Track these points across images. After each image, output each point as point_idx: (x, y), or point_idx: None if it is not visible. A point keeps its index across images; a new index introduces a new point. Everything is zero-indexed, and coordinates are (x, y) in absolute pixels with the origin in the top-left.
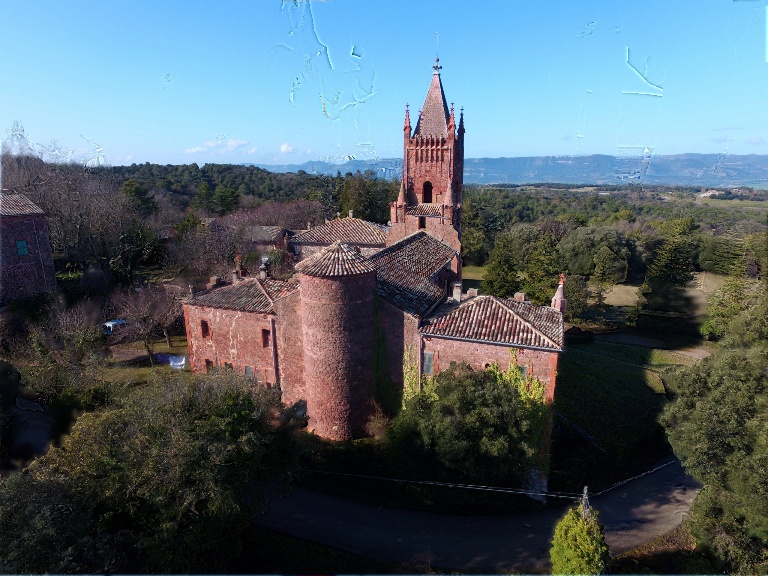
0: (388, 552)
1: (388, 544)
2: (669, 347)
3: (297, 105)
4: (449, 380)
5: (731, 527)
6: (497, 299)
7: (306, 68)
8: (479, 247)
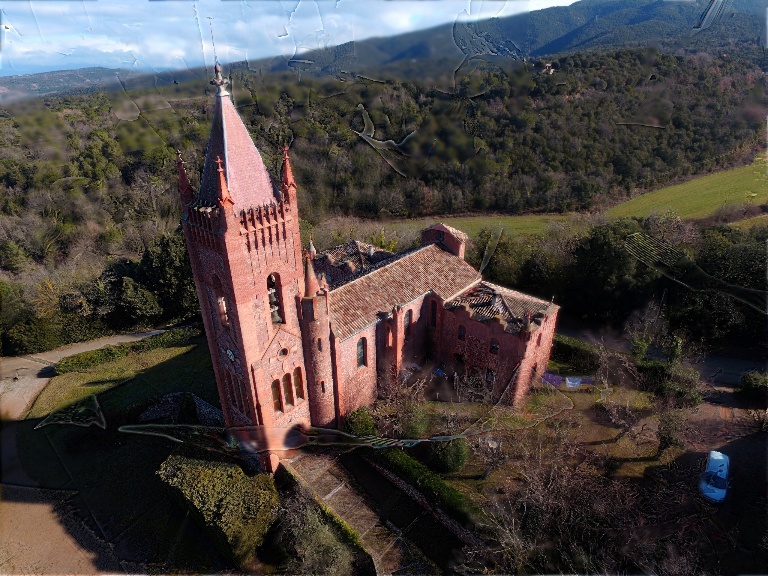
0: None
1: None
2: (4, 424)
3: (467, 158)
4: None
5: None
6: None
7: (455, 102)
8: None
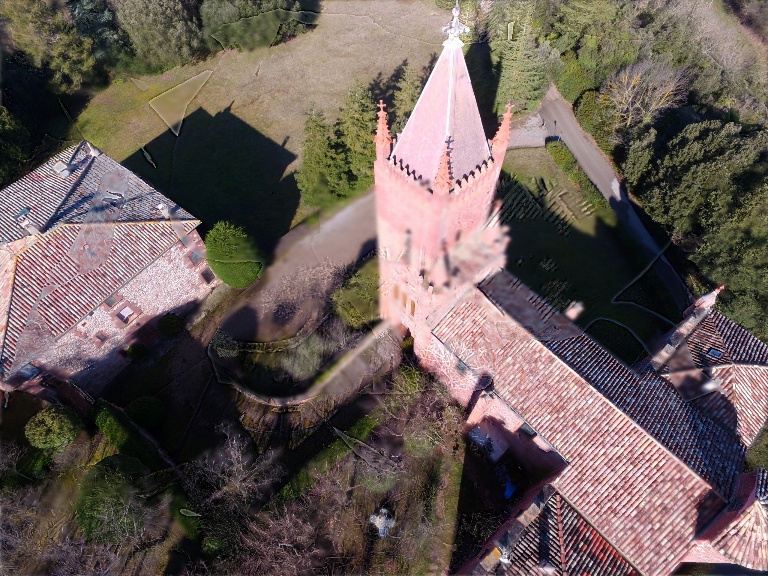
0: None
1: None
2: None
3: None
4: (759, 451)
5: (766, 338)
6: (736, 362)
7: None
8: (94, 62)
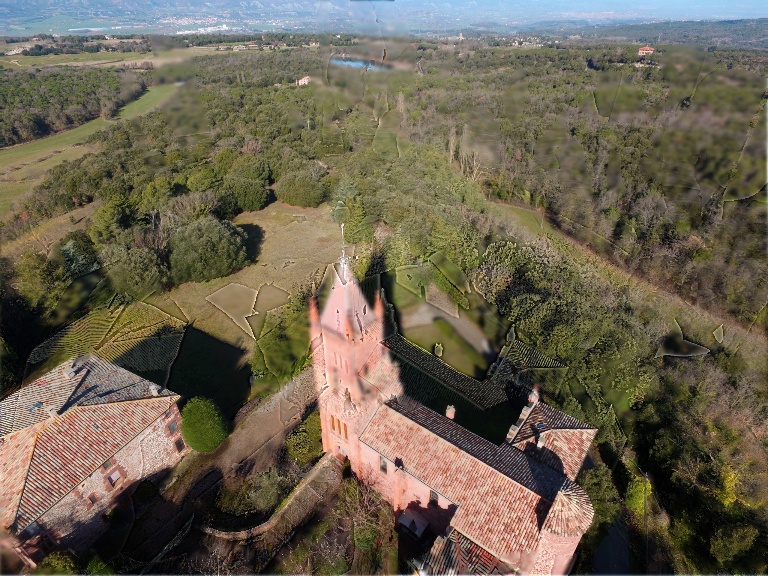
0: (625, 575)
1: (620, 573)
2: None
3: None
4: None
5: None
6: None
7: None
8: None
